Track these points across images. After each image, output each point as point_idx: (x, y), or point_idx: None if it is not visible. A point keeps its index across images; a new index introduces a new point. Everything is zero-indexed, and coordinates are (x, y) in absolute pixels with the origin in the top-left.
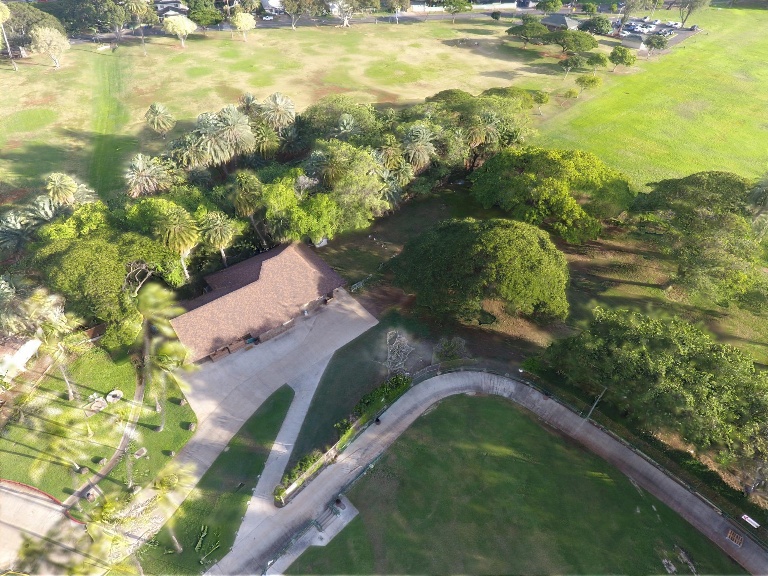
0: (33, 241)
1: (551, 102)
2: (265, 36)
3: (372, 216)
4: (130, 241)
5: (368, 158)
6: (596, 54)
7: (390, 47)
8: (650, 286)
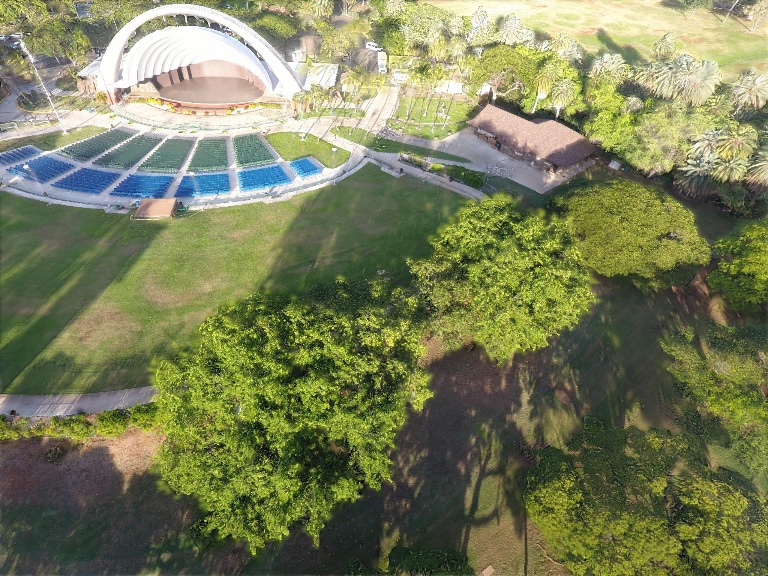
0: None
1: None
2: None
3: (652, 167)
4: None
5: (695, 121)
6: None
7: None
8: None
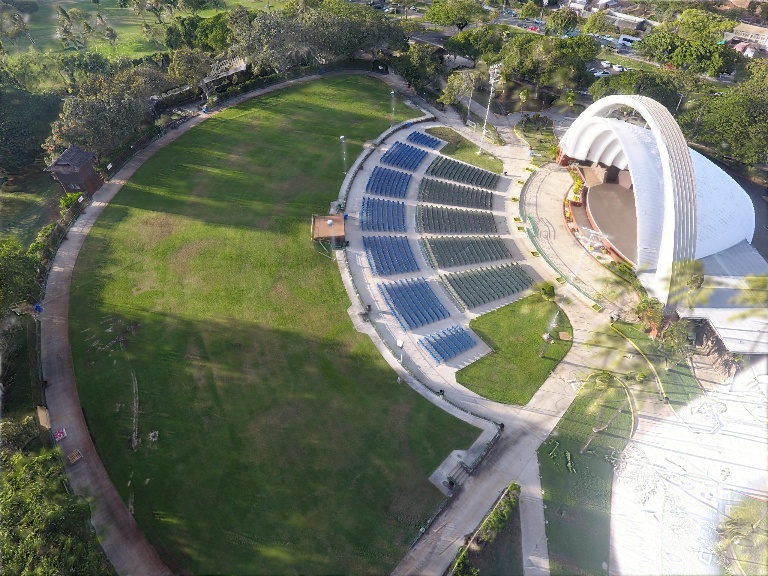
0: None
1: None
2: None
3: None
4: None
5: None
6: None
7: None
8: None
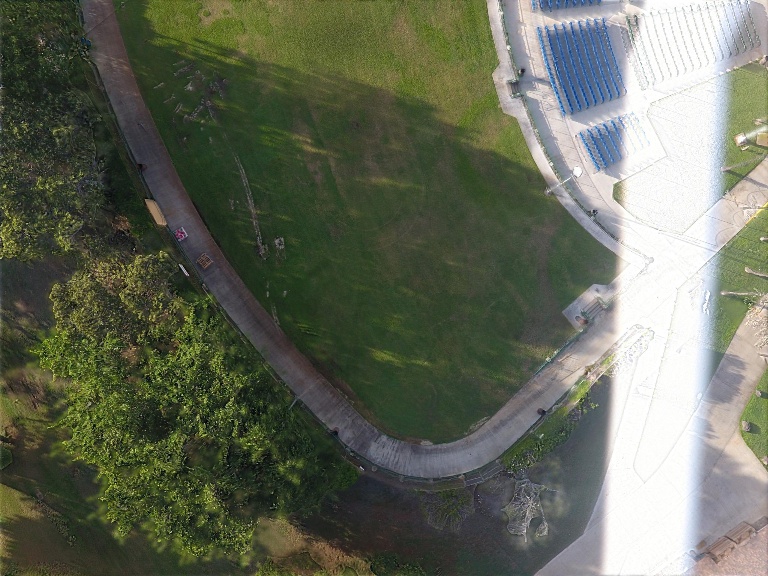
0: None
1: None
2: None
3: None
4: None
5: None
6: None
7: None
8: None
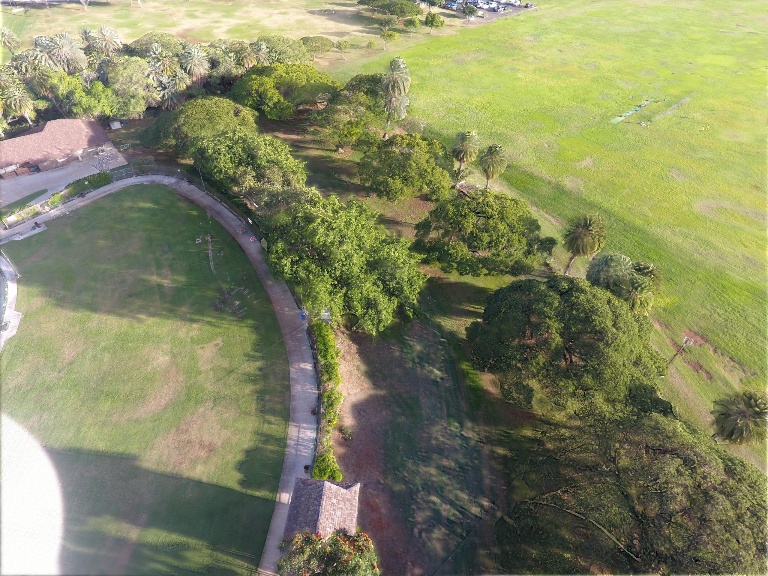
0: None
1: (360, 52)
2: (160, 4)
3: (148, 105)
4: None
5: (139, 62)
6: (410, 18)
7: (261, 14)
8: (329, 150)
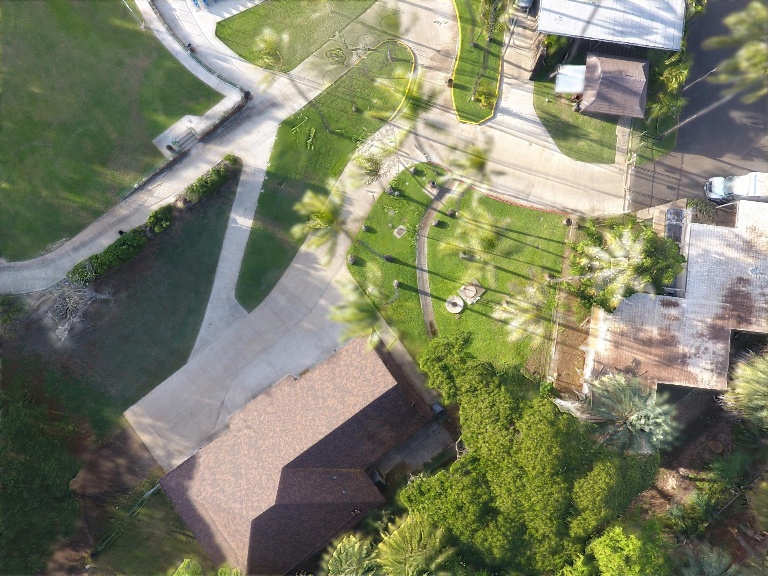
0: (675, 567)
1: None
2: None
3: None
4: (485, 524)
5: None
6: None
7: None
8: None
